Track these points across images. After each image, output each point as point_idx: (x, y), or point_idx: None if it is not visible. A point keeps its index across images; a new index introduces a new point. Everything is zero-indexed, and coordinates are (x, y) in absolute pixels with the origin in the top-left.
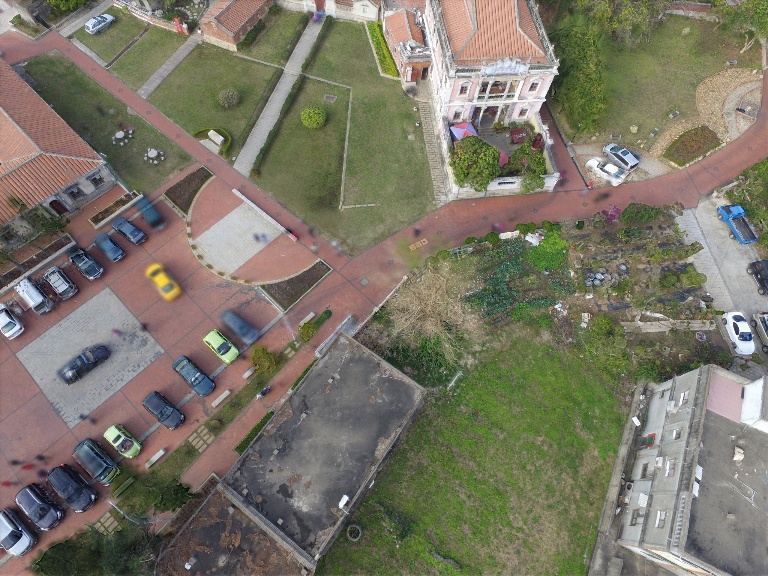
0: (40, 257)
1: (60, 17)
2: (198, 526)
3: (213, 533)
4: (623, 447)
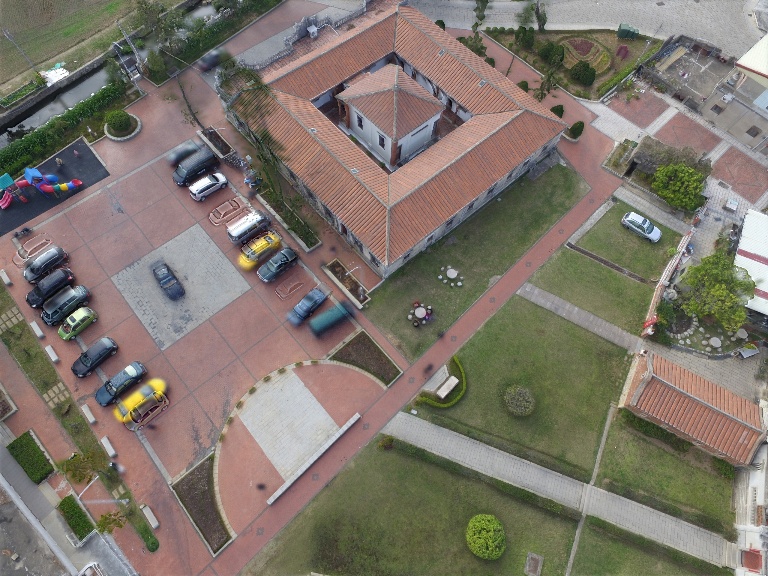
0: None
1: (646, 184)
2: None
3: None
4: None
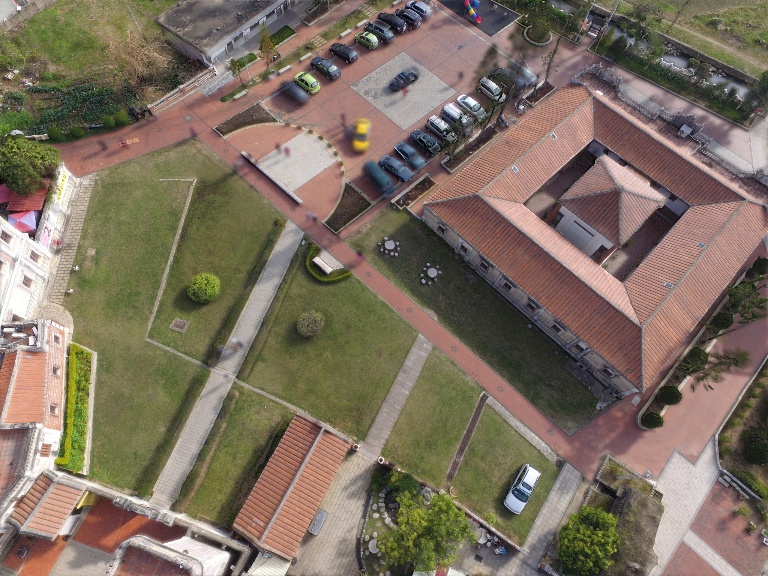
0: (467, 153)
1: None
2: None
3: None
4: (38, 5)
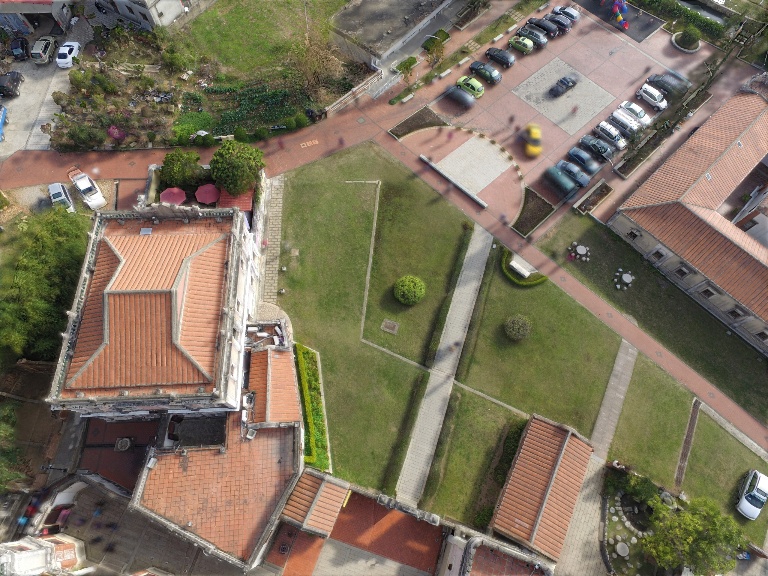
0: (638, 159)
1: None
2: None
3: None
4: (201, 6)
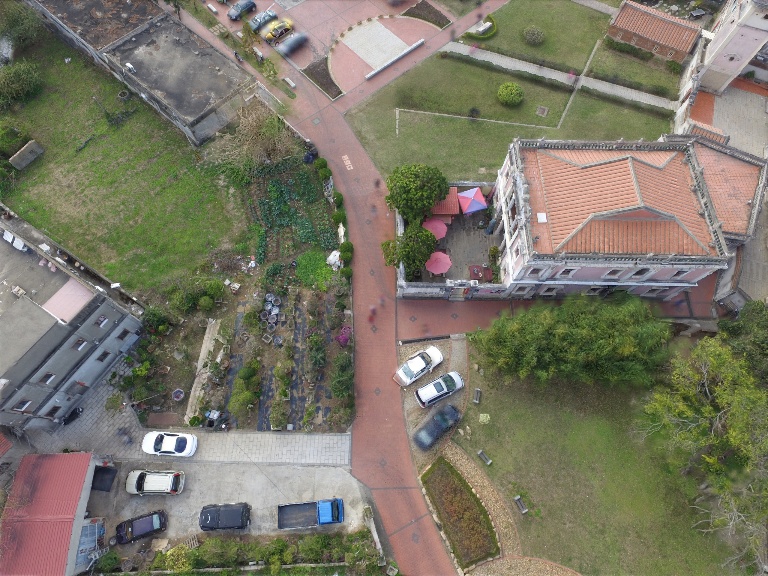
0: None
1: None
2: (148, 5)
3: (141, 11)
4: None
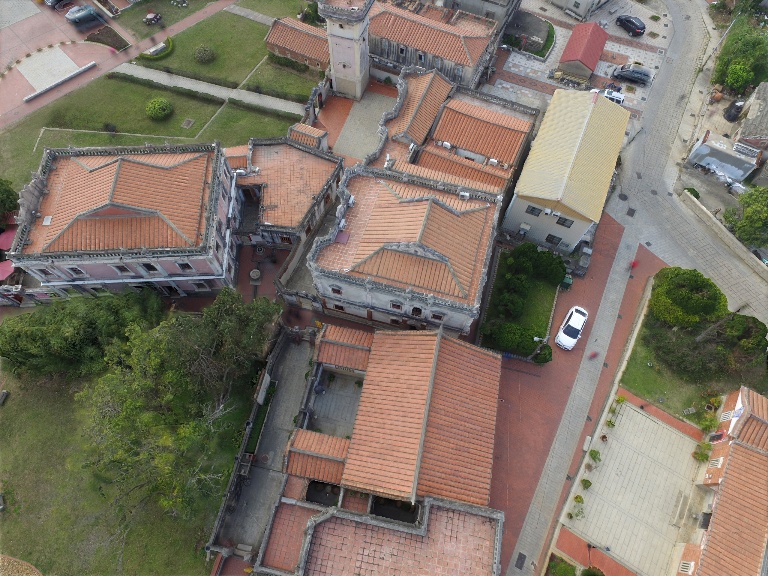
0: None
1: None
2: None
3: None
4: None
